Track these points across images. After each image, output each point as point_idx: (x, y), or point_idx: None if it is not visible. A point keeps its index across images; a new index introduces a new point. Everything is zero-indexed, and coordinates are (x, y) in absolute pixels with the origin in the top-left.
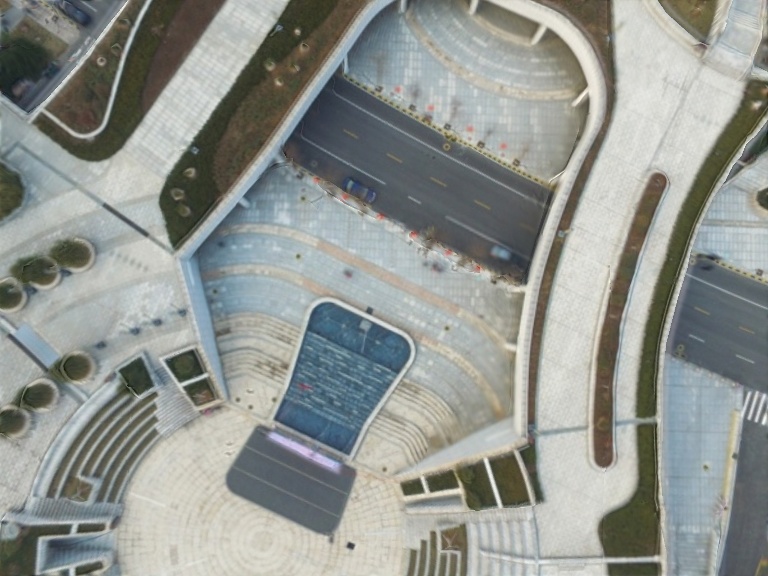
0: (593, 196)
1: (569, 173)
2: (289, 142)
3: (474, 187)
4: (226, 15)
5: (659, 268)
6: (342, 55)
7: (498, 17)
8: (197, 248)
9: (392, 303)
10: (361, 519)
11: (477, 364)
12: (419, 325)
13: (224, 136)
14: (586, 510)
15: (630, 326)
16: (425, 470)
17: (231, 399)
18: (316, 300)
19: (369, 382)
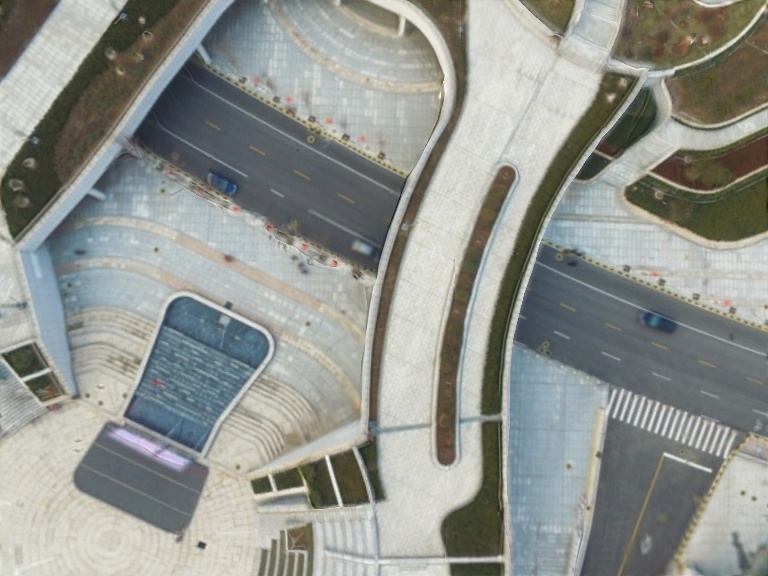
0: (440, 189)
1: (417, 165)
2: (140, 133)
3: (338, 180)
4: (70, 2)
5: (506, 262)
6: (193, 44)
7: (360, 7)
8: (43, 240)
9: (252, 298)
10: (213, 518)
11: (338, 360)
12: (279, 320)
13: (66, 126)
14: (429, 509)
15: (476, 321)
16: (274, 468)
17: (80, 395)
18: (173, 294)
19: (225, 378)
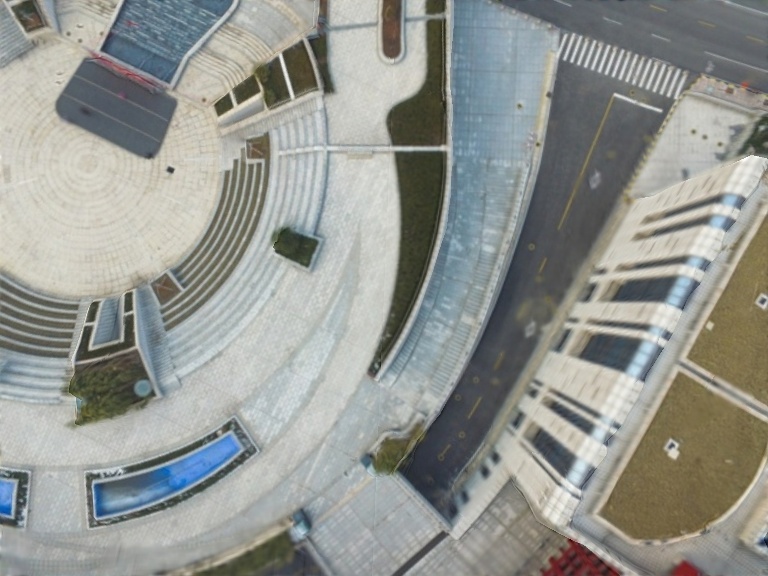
0: None
1: None
2: None
3: None
4: None
5: None
6: None
7: None
8: None
9: None
10: (181, 145)
11: (299, 11)
12: None
13: None
14: (375, 102)
15: None
16: None
17: (62, 33)
18: None
19: (194, 23)
